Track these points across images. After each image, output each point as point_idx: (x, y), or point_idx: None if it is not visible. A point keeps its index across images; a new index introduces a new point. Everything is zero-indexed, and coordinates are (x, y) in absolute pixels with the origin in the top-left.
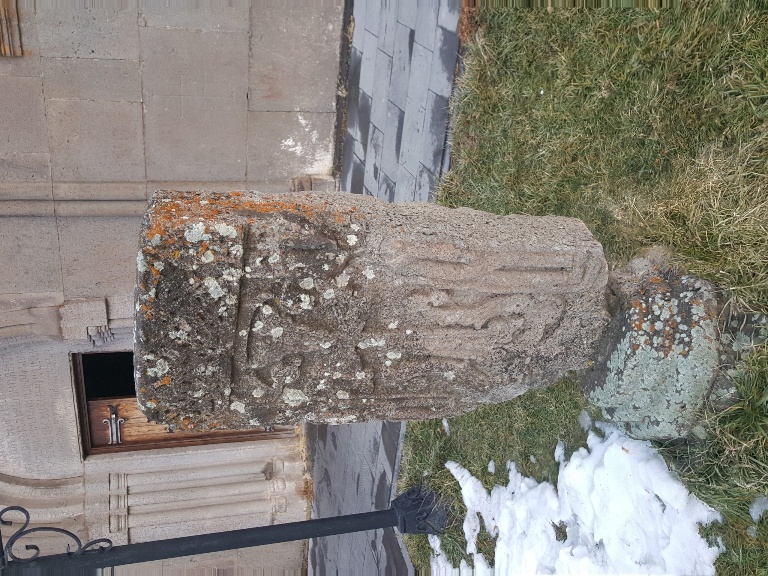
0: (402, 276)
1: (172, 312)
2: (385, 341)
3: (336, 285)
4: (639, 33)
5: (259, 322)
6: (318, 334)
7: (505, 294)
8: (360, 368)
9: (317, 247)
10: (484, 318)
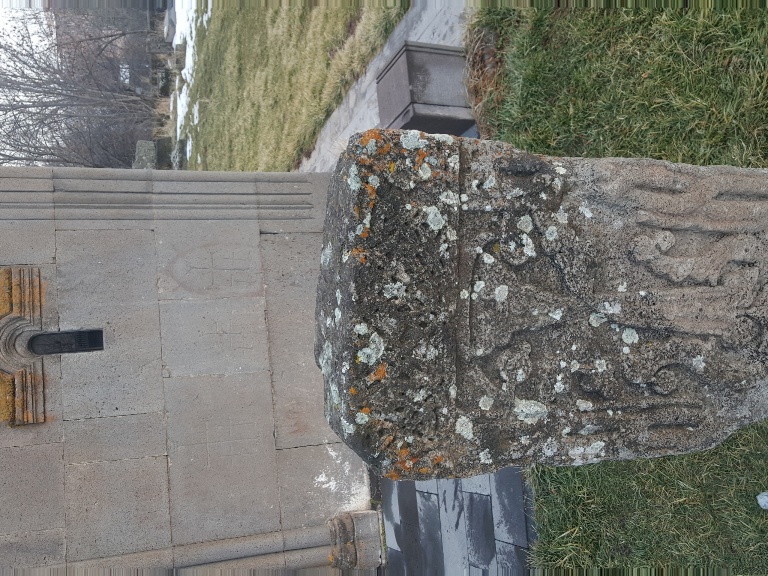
0: (619, 216)
1: (387, 256)
2: (620, 306)
3: (557, 220)
4: (698, 129)
5: (479, 282)
6: (546, 297)
7: (729, 234)
8: (599, 352)
9: (531, 169)
10: (717, 268)
